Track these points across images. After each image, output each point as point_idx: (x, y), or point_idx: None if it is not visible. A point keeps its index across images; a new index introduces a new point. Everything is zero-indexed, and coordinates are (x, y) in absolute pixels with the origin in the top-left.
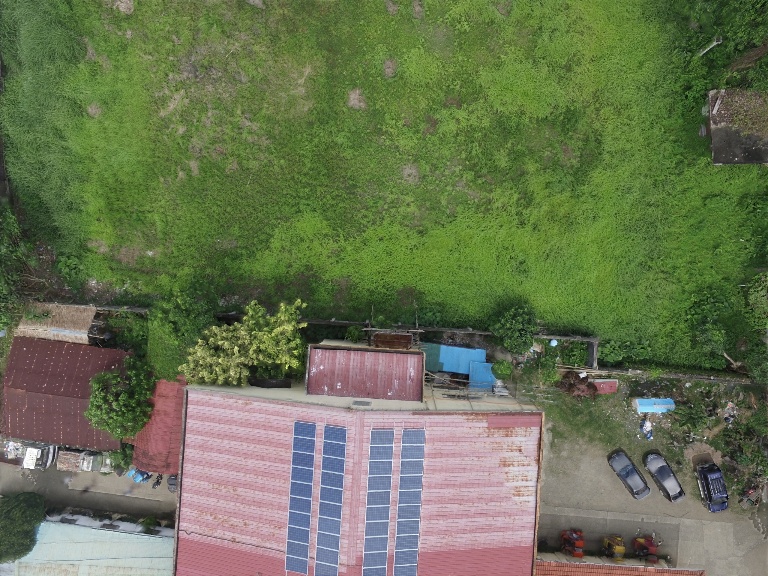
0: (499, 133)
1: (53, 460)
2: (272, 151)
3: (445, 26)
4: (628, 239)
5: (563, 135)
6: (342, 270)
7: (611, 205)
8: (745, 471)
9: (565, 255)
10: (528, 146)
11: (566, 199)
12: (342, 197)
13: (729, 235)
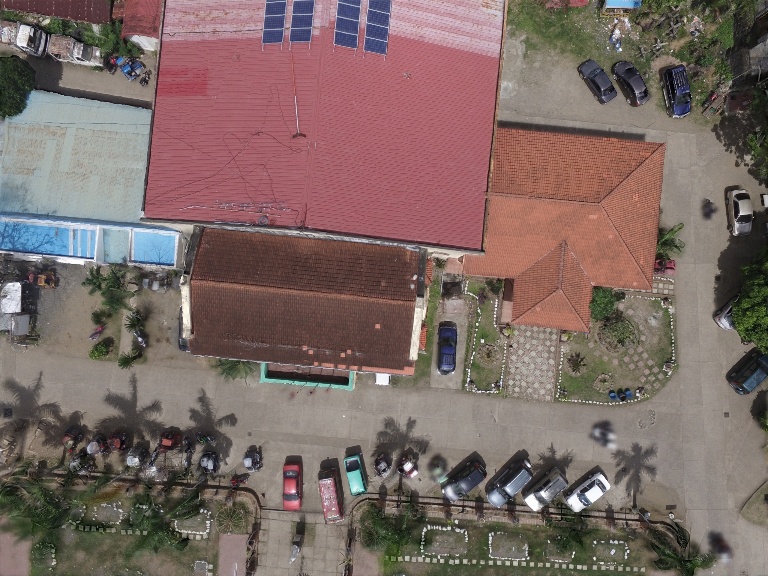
0: None
1: (45, 49)
2: None
3: None
4: None
5: None
6: None
7: None
8: (709, 83)
9: None
10: None
11: None
12: None
13: None
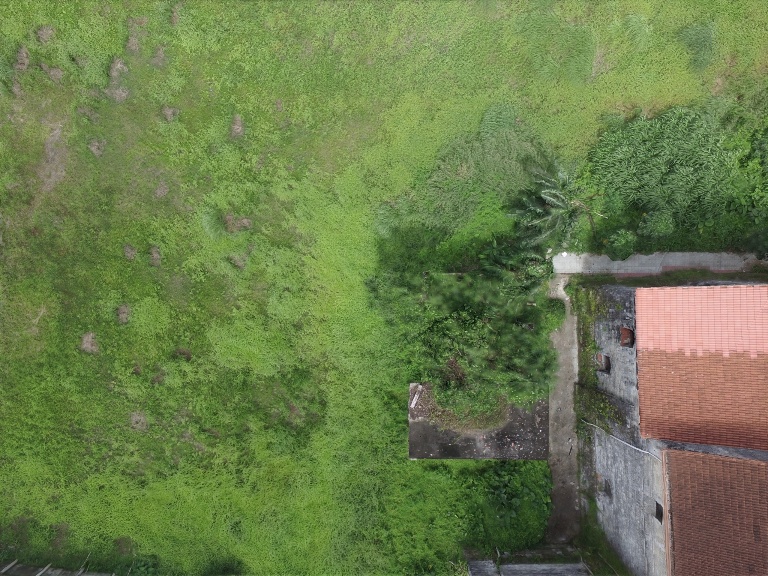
0: (226, 388)
1: None
2: (0, 391)
3: (182, 274)
4: (342, 508)
5: (289, 394)
6: (60, 517)
7: (328, 472)
8: None
9: (279, 519)
10: (256, 401)
11: (286, 461)
12: (67, 441)
13: (446, 509)
